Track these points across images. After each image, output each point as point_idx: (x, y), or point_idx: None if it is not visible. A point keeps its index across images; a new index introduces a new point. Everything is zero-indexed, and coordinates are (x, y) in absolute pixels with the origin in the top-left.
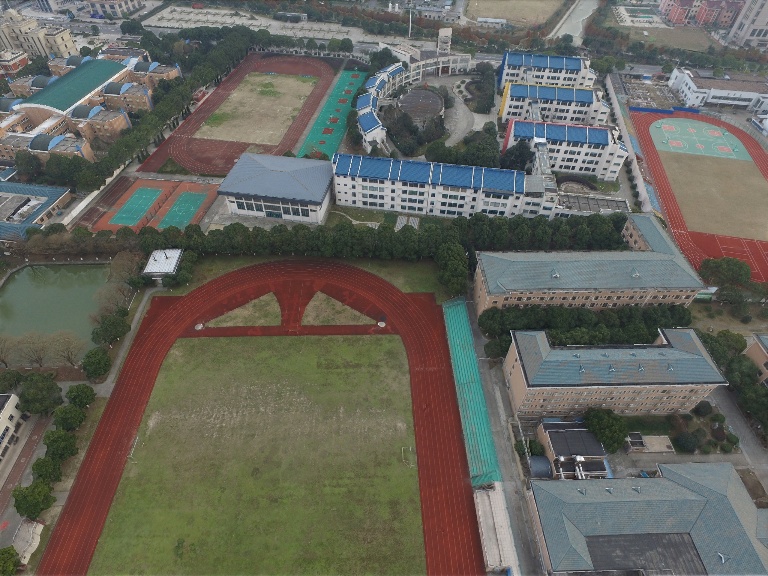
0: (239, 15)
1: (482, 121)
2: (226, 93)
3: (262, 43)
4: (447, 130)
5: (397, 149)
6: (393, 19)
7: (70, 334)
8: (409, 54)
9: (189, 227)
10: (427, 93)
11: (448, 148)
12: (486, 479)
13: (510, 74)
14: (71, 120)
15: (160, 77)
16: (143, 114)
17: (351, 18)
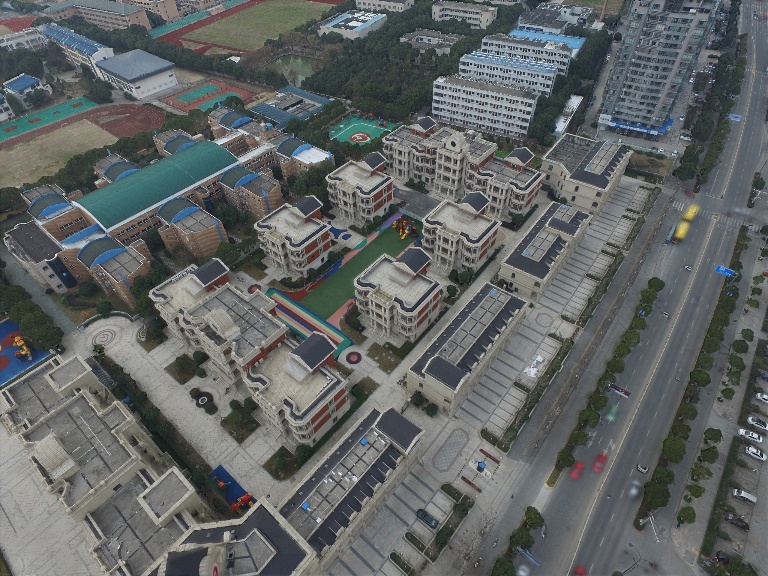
0: None
1: None
2: None
3: None
4: None
5: None
6: None
7: (284, 37)
8: None
9: (208, 57)
10: None
11: (28, 57)
12: (206, 13)
13: None
14: None
15: None
16: None
17: None
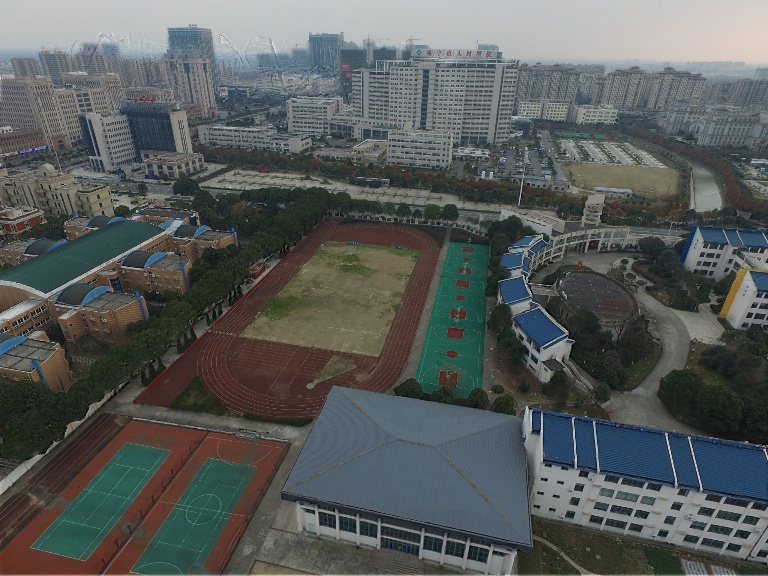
0: (310, 179)
1: (696, 324)
2: (294, 267)
3: (341, 207)
4: (653, 339)
5: (586, 373)
6: (490, 186)
7: None
8: (550, 224)
9: None
10: (595, 278)
11: (722, 390)
12: None
13: (706, 254)
14: (54, 306)
15: (207, 245)
16: (171, 297)
17: (443, 184)
